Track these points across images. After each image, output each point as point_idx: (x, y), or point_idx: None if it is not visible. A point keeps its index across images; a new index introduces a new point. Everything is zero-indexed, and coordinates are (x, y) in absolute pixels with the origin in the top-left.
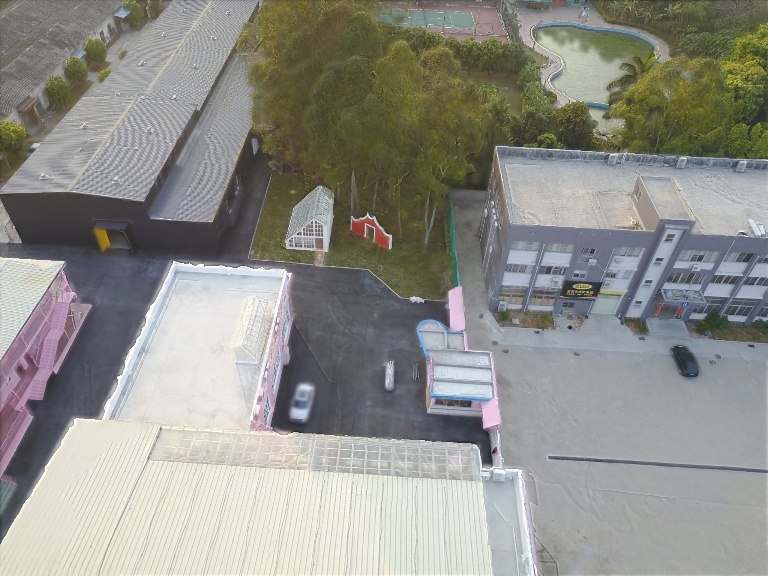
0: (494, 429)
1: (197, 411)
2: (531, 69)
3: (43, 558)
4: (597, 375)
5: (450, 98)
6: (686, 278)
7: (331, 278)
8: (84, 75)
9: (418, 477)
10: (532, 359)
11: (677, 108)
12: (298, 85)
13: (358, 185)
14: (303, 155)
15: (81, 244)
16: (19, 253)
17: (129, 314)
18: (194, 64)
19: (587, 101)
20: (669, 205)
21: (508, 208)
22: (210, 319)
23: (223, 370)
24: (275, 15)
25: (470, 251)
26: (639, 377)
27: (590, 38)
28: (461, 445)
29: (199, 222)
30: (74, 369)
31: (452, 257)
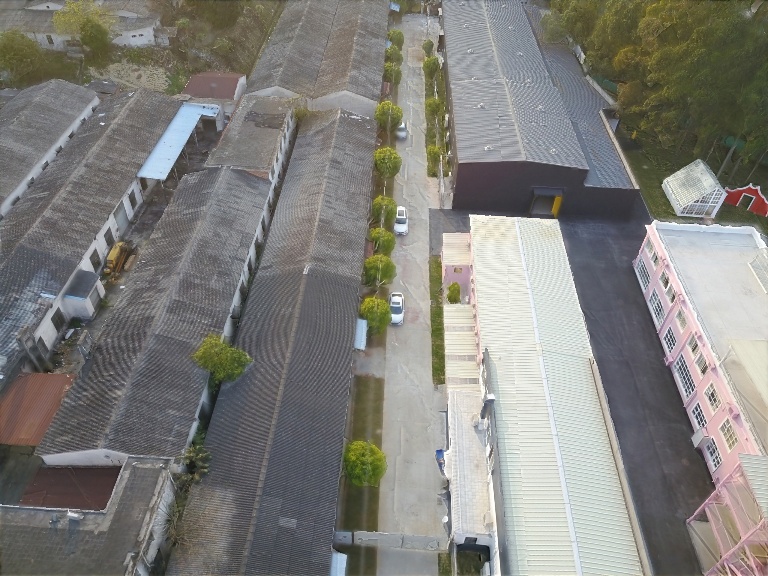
0: None
1: None
2: None
3: None
4: None
5: None
6: None
7: None
8: (400, 63)
9: None
10: None
11: None
12: (743, 65)
13: None
14: (700, 130)
15: (505, 210)
16: (456, 217)
17: (591, 269)
18: (519, 52)
19: None
20: None
21: None
22: (719, 267)
23: (767, 308)
24: (701, 3)
25: None
26: None
27: None
28: None
29: (628, 189)
30: None
31: None
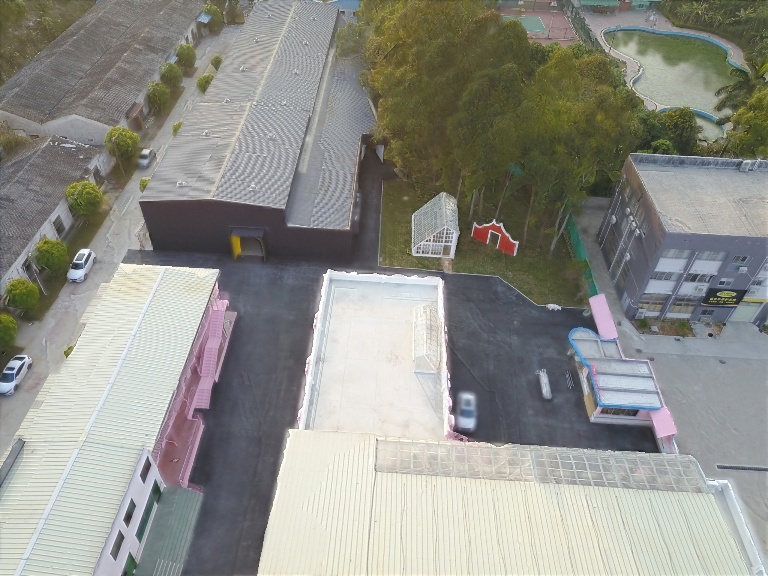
0: (670, 439)
1: (389, 421)
2: (617, 74)
3: (308, 572)
4: (747, 383)
5: (612, 106)
6: None
7: (464, 285)
8: (179, 81)
9: (648, 489)
10: (679, 367)
11: None
12: (445, 92)
13: None
14: (432, 162)
15: (212, 251)
16: (153, 260)
17: (275, 322)
18: (295, 70)
19: (673, 106)
20: None
21: None
22: (377, 328)
23: (404, 379)
24: (414, 22)
25: (593, 258)
26: None
27: (661, 42)
28: (678, 456)
29: (336, 229)
30: (233, 377)
31: None
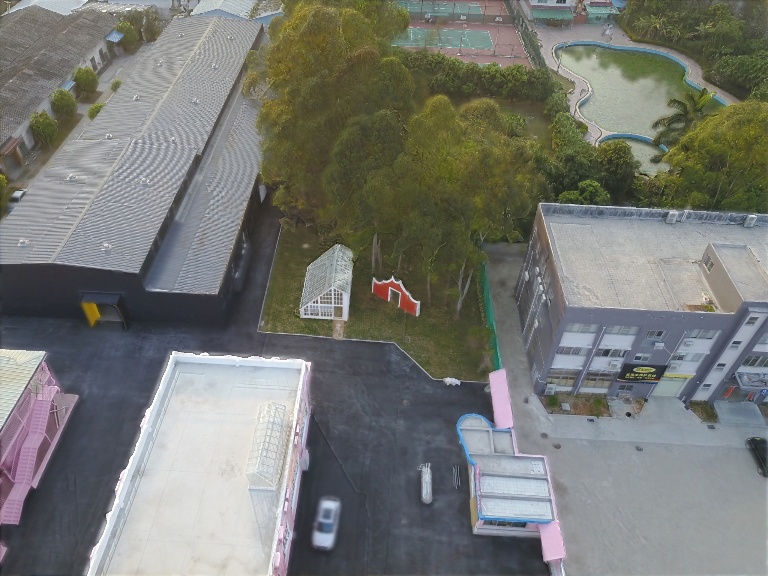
0: (557, 563)
1: (203, 560)
2: (559, 97)
3: None
4: (665, 476)
5: (498, 162)
6: (765, 361)
7: (353, 354)
8: (73, 109)
9: None
10: (588, 456)
11: (742, 157)
12: (316, 141)
13: (378, 237)
14: (319, 213)
15: (67, 316)
16: None
17: (122, 406)
18: (194, 99)
19: (620, 132)
20: (750, 281)
21: (561, 283)
22: (217, 427)
23: (234, 499)
24: (288, 57)
25: (507, 316)
26: (713, 478)
27: (616, 59)
28: None
29: (202, 294)
30: (57, 481)
31: (490, 330)
